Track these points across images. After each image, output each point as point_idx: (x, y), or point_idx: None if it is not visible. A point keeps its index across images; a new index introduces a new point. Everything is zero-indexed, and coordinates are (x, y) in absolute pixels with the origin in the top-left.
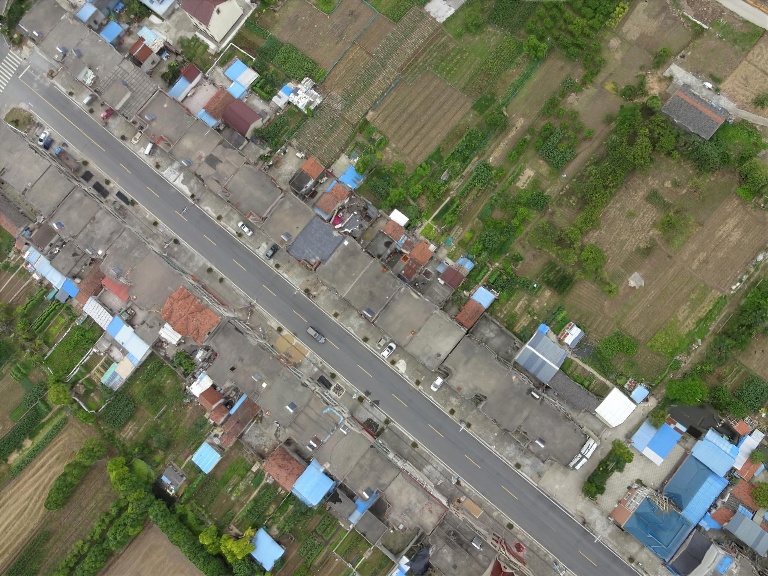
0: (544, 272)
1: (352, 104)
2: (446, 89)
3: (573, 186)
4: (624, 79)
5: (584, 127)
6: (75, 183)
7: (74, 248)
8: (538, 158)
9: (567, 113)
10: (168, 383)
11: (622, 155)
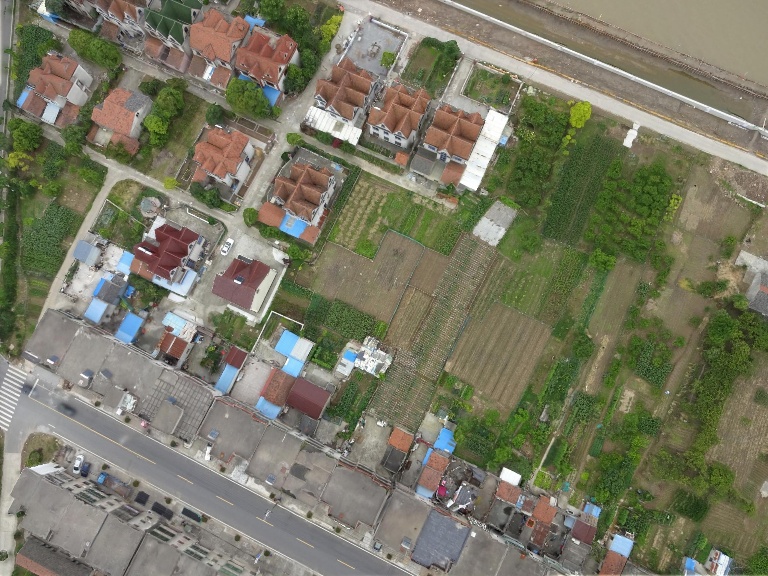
0: (674, 501)
1: (426, 358)
2: (519, 319)
3: (683, 406)
4: (696, 273)
5: (672, 334)
6: (139, 524)
7: None
8: (634, 377)
9: (651, 322)
10: None
11: (724, 364)
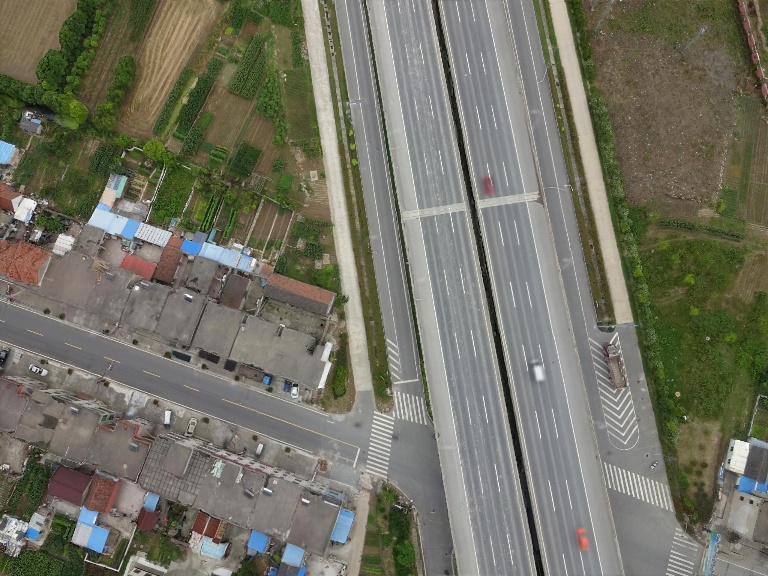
0: None
1: None
2: None
3: None
4: None
5: None
6: None
7: (199, 286)
8: None
9: None
10: (70, 201)
11: None
